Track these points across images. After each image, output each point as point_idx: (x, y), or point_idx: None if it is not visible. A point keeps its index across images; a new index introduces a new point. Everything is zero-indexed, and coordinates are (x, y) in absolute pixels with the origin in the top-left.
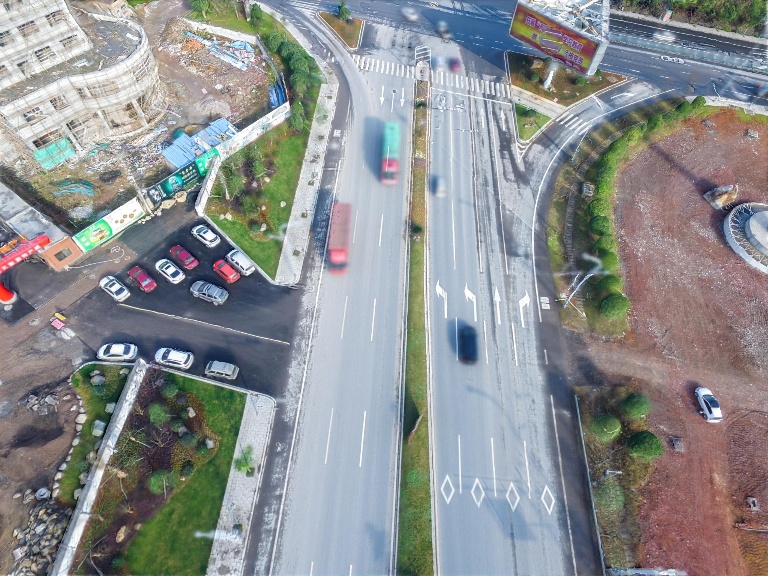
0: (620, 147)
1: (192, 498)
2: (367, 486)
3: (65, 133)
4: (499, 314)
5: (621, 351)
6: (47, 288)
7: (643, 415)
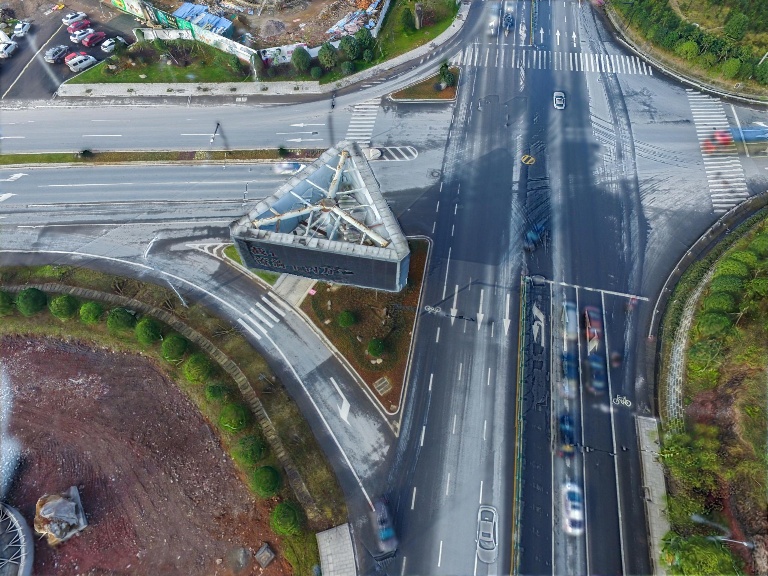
0: None
1: None
2: None
3: None
4: None
5: None
6: None
7: None
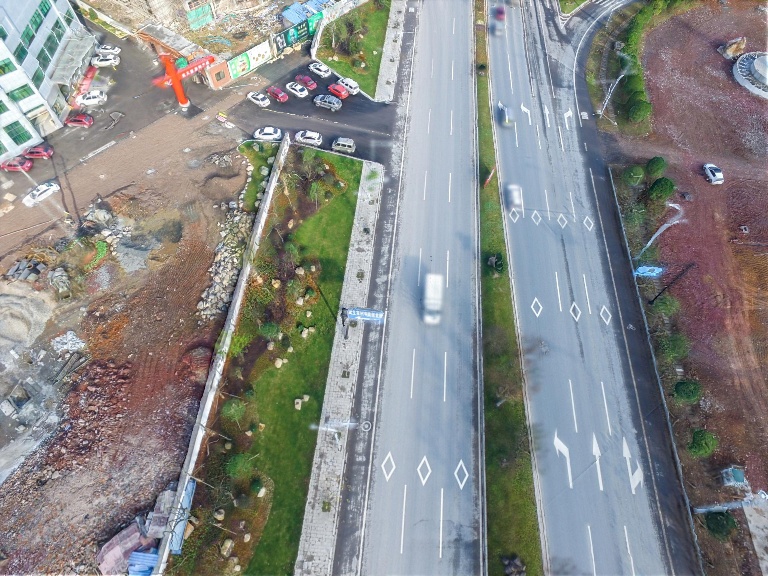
0: (647, 12)
1: (334, 212)
2: (455, 212)
3: (208, 0)
4: (548, 121)
5: (645, 145)
6: (209, 99)
7: None
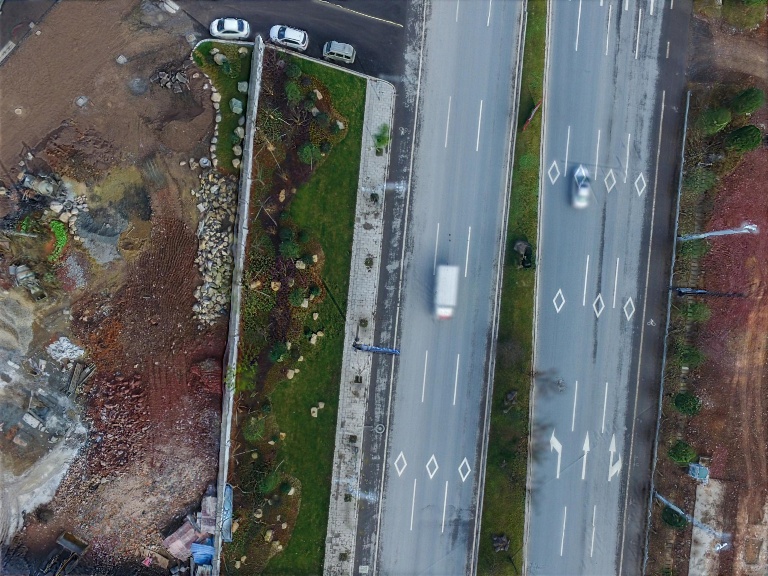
0: None
1: (333, 171)
2: (483, 167)
3: None
4: None
5: (748, 46)
6: None
7: (749, 113)
